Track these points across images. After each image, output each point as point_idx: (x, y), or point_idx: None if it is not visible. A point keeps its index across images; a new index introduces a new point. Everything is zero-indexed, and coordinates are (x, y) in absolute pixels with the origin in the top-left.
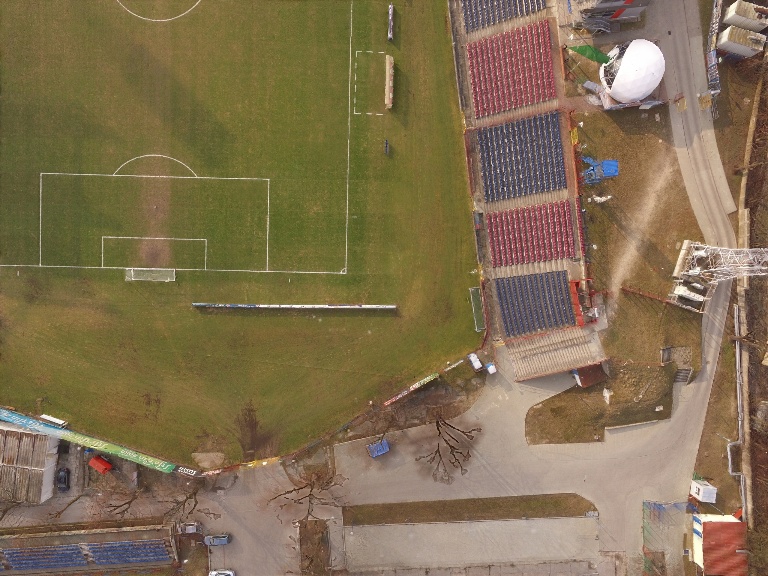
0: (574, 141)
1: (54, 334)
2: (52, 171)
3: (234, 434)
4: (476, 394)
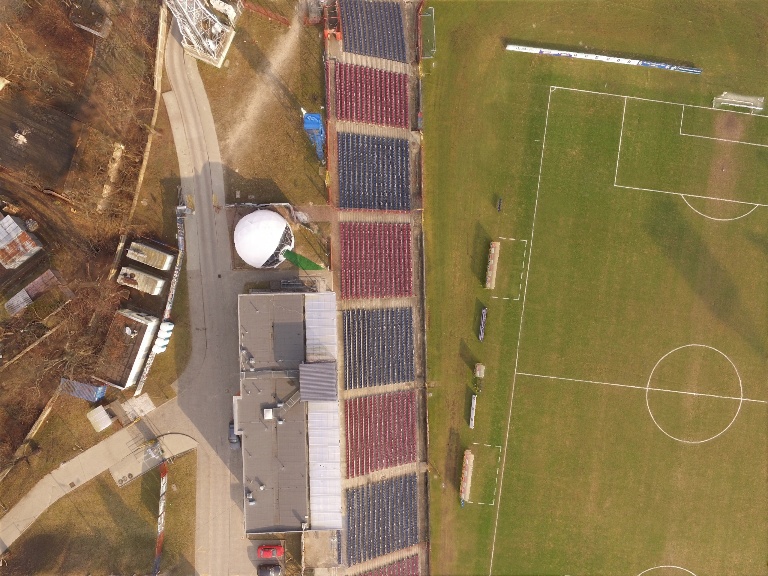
0: None
1: None
2: None
3: None
4: None
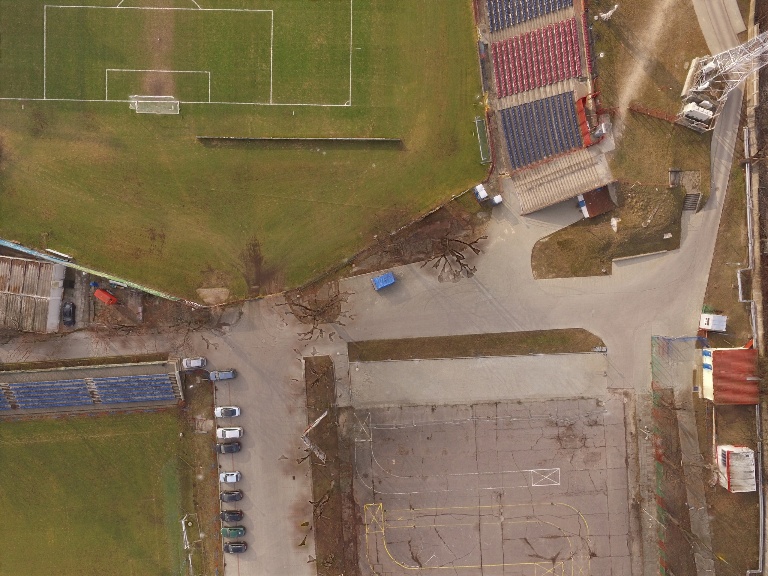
0: None
1: (59, 168)
2: (56, 3)
3: (239, 269)
4: (482, 228)
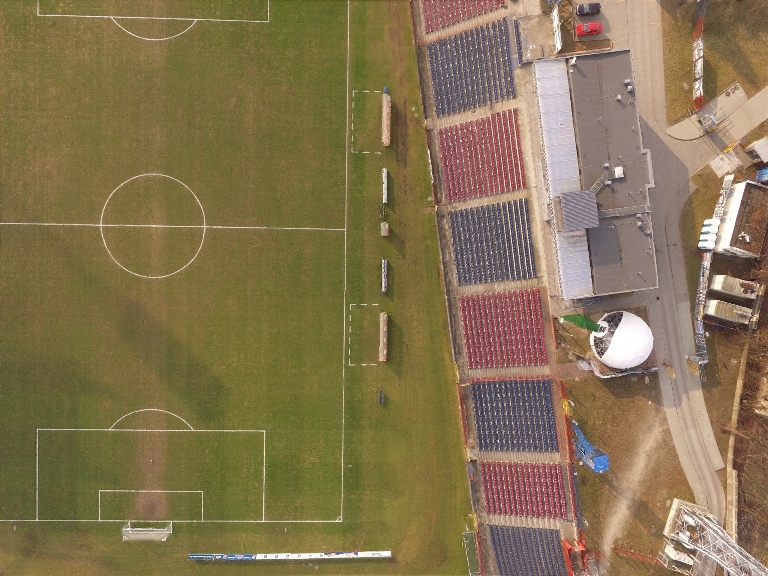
0: (565, 409)
1: None
2: (48, 427)
3: None
4: None
